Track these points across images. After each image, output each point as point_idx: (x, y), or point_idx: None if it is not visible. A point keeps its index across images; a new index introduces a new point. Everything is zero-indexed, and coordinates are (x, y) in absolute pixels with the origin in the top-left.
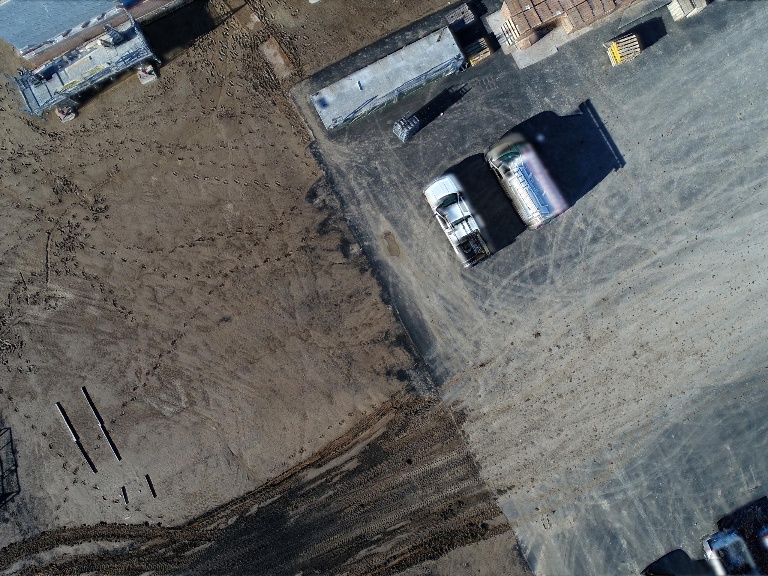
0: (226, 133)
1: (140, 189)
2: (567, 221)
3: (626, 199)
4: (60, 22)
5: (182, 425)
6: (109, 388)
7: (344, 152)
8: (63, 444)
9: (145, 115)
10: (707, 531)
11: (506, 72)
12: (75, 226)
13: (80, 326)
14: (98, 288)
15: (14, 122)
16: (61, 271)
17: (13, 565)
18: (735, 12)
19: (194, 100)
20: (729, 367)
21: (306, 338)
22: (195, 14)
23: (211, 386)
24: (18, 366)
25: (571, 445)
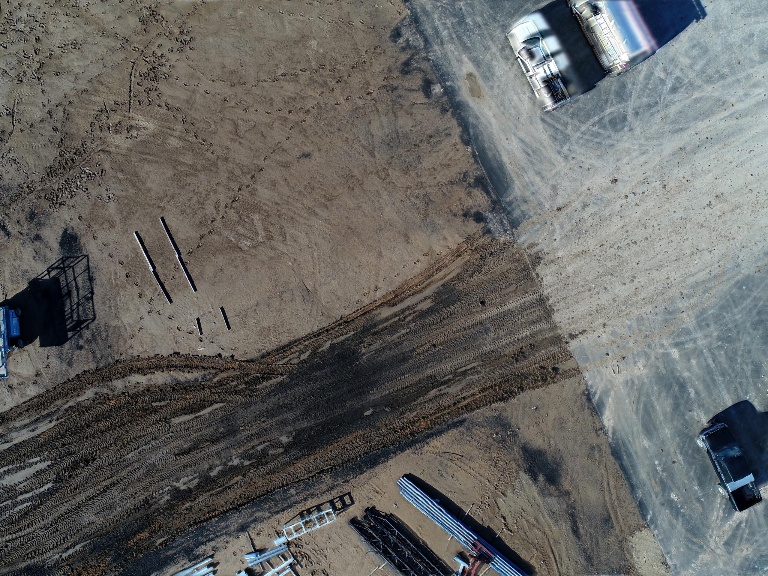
0: None
1: (225, 22)
2: (647, 70)
3: (706, 50)
4: None
5: (258, 259)
6: (187, 219)
7: None
8: (139, 273)
9: None
10: None
11: None
12: (159, 56)
13: (161, 156)
14: (180, 119)
15: None
16: (144, 101)
17: (85, 392)
18: None
19: None
20: None
21: (384, 177)
22: None
23: (288, 221)
24: (98, 194)
25: (643, 292)
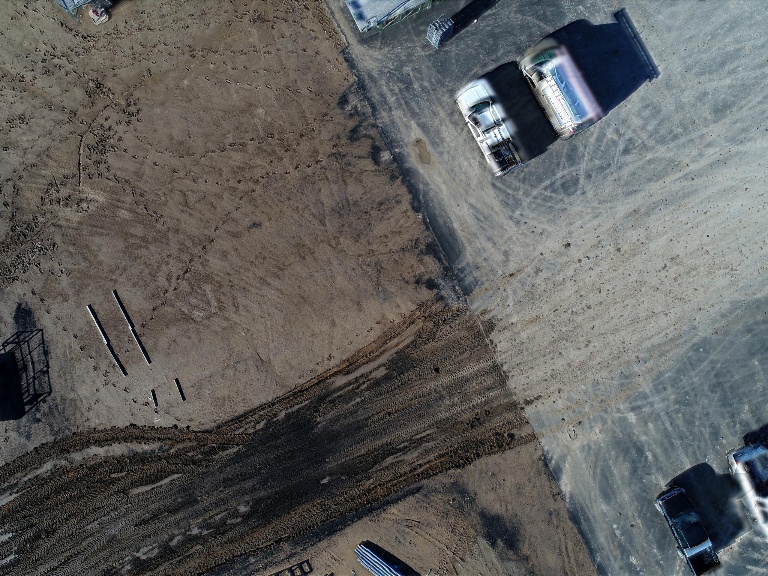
0: (259, 38)
1: (172, 93)
2: (600, 131)
3: (660, 110)
4: None
5: (211, 330)
6: (140, 292)
7: (377, 58)
8: (94, 347)
9: (178, 18)
10: (733, 445)
11: None
12: (107, 129)
13: (112, 230)
14: (130, 192)
15: (48, 24)
16: (93, 174)
17: (44, 465)
18: None
19: (227, 4)
20: (759, 281)
21: (336, 245)
22: None
23: (241, 292)
24: (50, 268)
25: (599, 356)
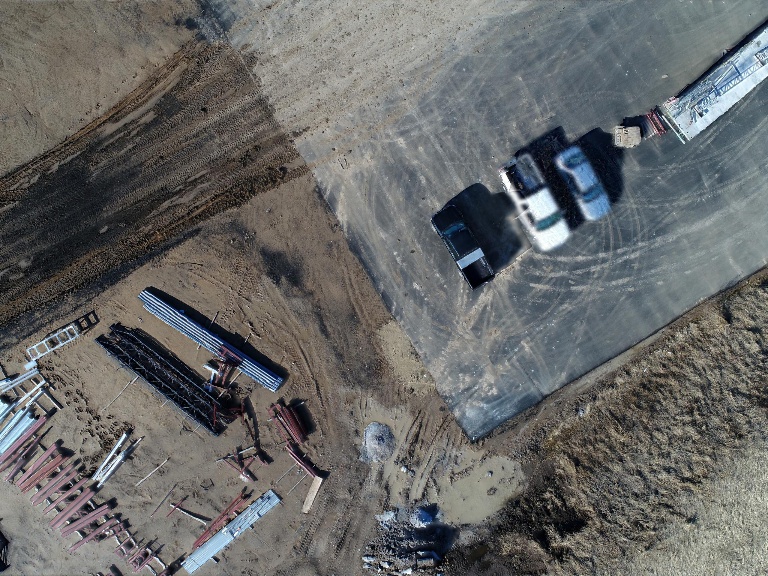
0: None
1: None
2: None
3: None
4: None
5: None
6: None
7: None
8: None
9: None
10: (505, 164)
11: None
12: None
13: None
14: None
15: None
16: None
17: None
18: None
19: None
20: None
21: None
22: None
23: (4, 47)
24: None
25: (363, 83)
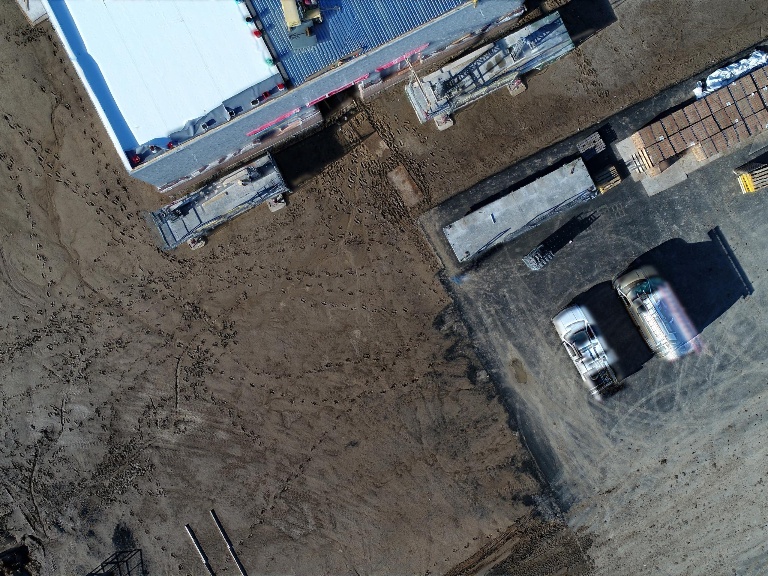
0: (354, 260)
1: (268, 315)
2: (694, 348)
3: (754, 326)
4: (201, 162)
5: (309, 547)
6: (237, 511)
7: (473, 280)
8: (192, 565)
9: (274, 242)
10: None
11: (635, 199)
12: (204, 352)
13: (209, 450)
14: (227, 413)
15: (144, 249)
16: (190, 396)
17: None
18: None
19: (322, 227)
20: None
21: (432, 463)
22: (325, 142)
23: (338, 509)
24: (148, 489)
25: (695, 570)
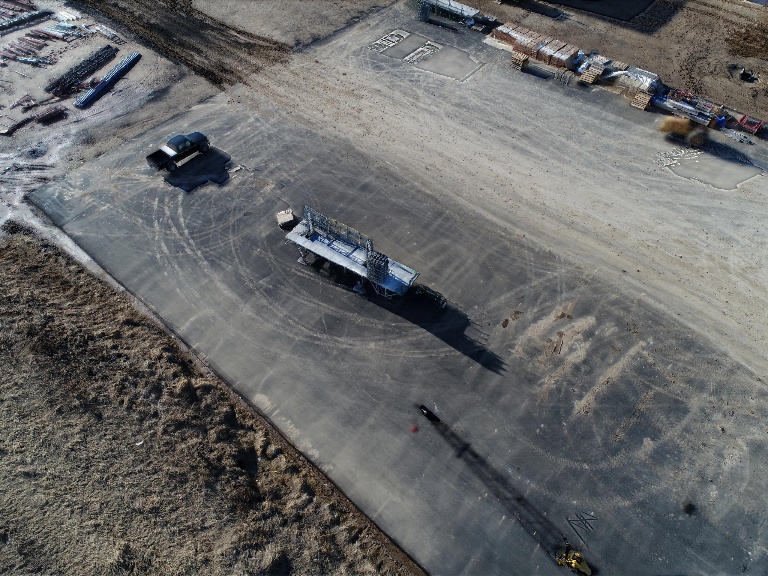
0: None
1: None
2: None
3: (443, 86)
4: None
5: (244, 0)
6: None
7: None
8: None
9: None
10: (249, 166)
11: None
12: None
13: None
14: None
15: None
16: None
17: None
18: (581, 98)
19: None
20: (367, 146)
21: None
22: None
23: (266, 3)
24: None
25: (284, 99)
